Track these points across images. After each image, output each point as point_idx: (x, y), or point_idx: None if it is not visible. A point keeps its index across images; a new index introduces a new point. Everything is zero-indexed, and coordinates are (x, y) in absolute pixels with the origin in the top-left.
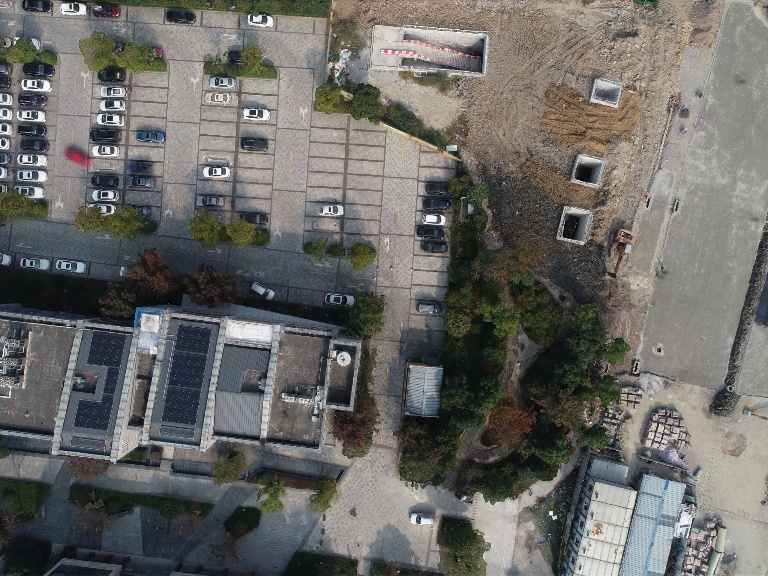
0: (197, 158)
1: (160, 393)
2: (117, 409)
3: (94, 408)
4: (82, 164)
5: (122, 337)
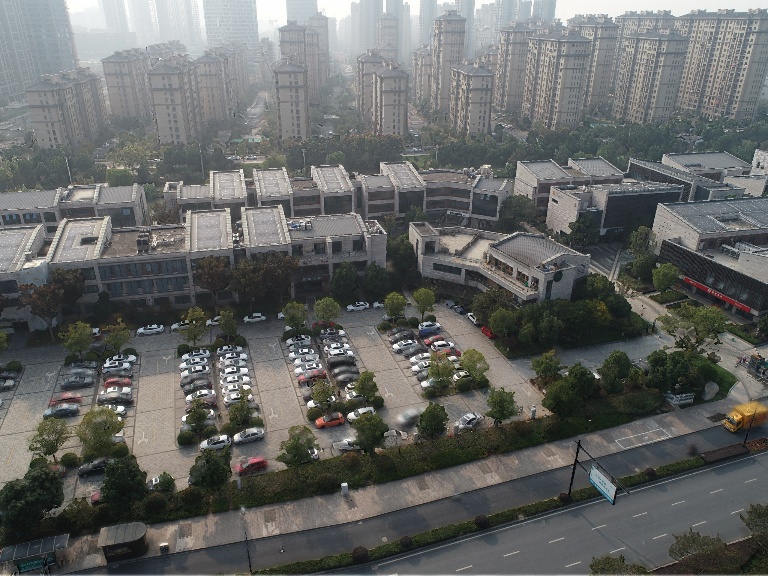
0: (8, 412)
1: (27, 242)
2: (64, 235)
3: (81, 233)
4: (145, 383)
5: (61, 261)
